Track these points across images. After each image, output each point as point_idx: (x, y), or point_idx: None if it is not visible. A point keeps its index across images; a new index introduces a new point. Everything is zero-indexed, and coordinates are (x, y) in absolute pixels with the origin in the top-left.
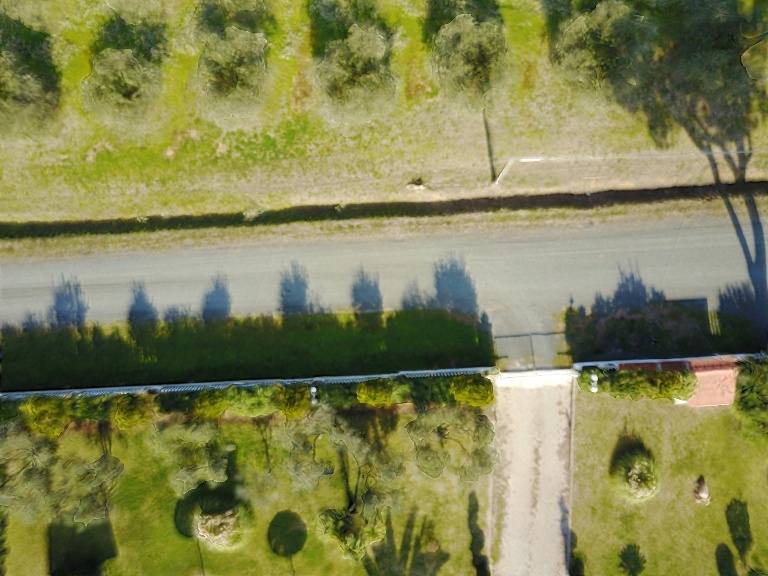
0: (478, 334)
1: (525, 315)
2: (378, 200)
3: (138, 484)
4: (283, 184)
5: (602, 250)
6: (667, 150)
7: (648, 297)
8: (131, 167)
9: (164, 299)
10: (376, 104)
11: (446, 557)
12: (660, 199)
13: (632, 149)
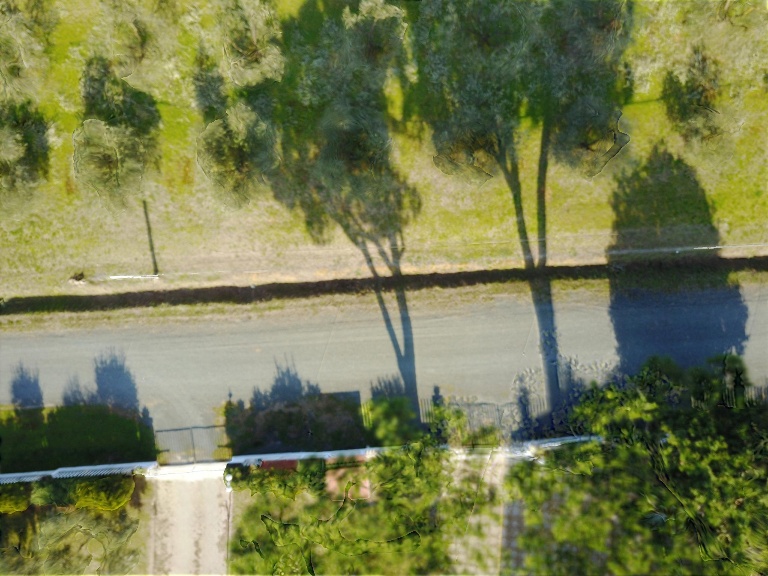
0: (139, 428)
1: (185, 409)
2: (44, 294)
3: None
4: None
5: (259, 344)
6: (324, 245)
7: (303, 390)
8: None
9: None
10: (12, 206)
11: None
12: (317, 293)
13: (290, 244)
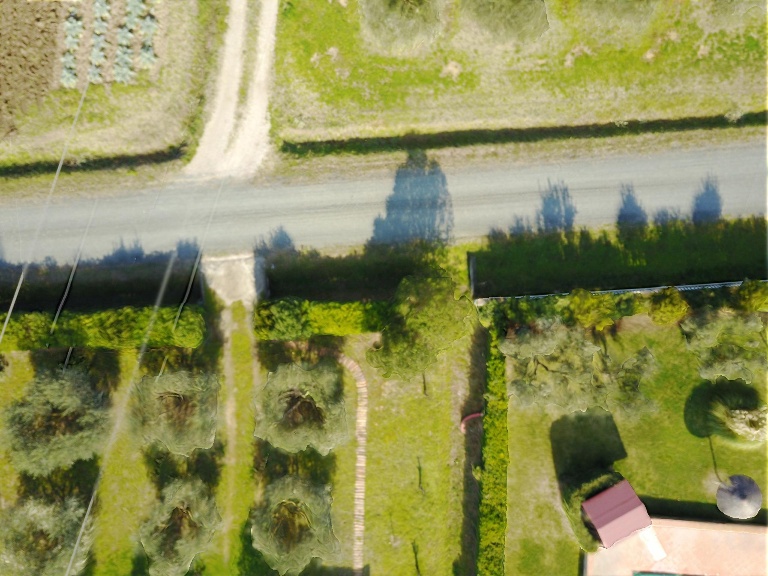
0: None
1: None
2: None
3: (640, 386)
4: (767, 85)
5: None
6: None
7: None
8: (611, 71)
9: (653, 202)
10: None
11: None
12: None
13: None
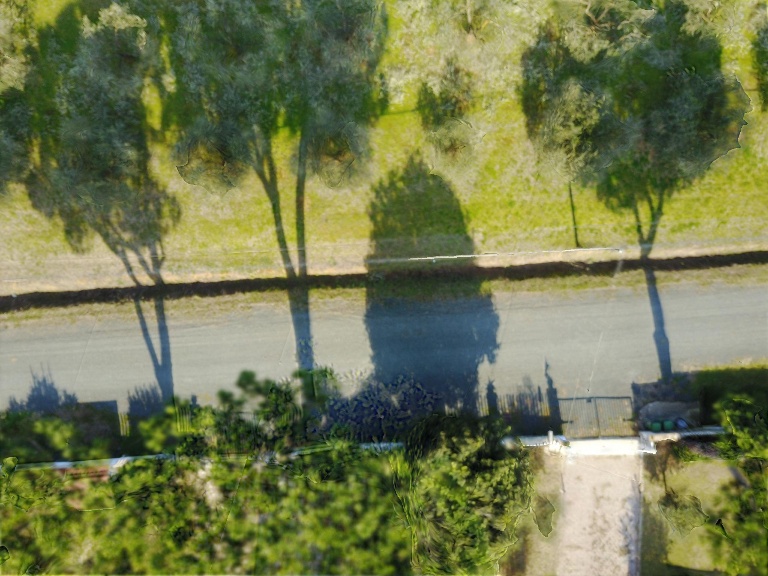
0: None
1: None
2: None
3: None
4: None
5: (15, 354)
6: (83, 254)
7: (60, 400)
8: None
9: None
10: None
11: None
12: (77, 302)
13: (49, 253)
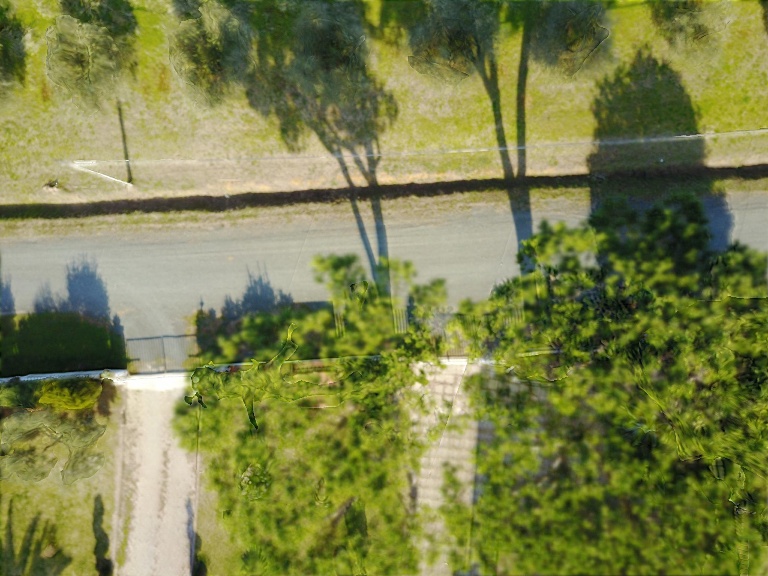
0: (110, 336)
1: (157, 317)
2: (18, 201)
3: None
4: None
5: (232, 252)
6: (299, 153)
7: (276, 299)
8: None
9: None
10: None
11: (68, 562)
12: (292, 202)
13: (265, 152)
